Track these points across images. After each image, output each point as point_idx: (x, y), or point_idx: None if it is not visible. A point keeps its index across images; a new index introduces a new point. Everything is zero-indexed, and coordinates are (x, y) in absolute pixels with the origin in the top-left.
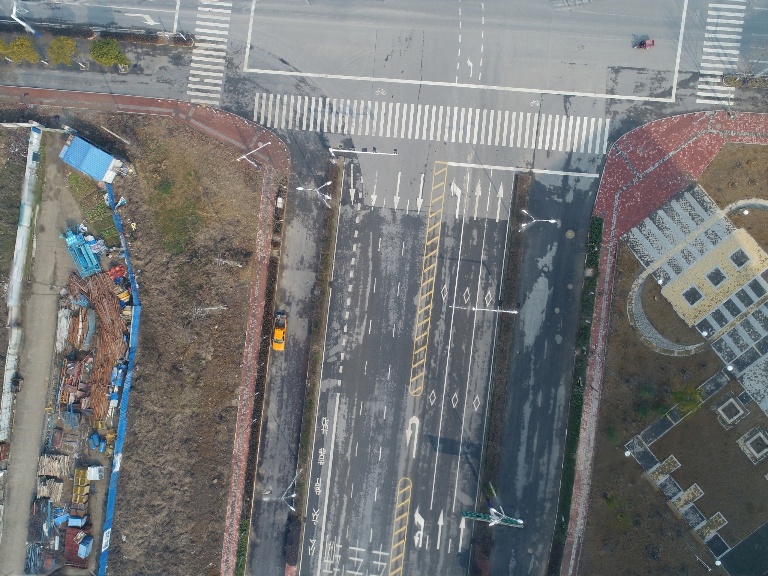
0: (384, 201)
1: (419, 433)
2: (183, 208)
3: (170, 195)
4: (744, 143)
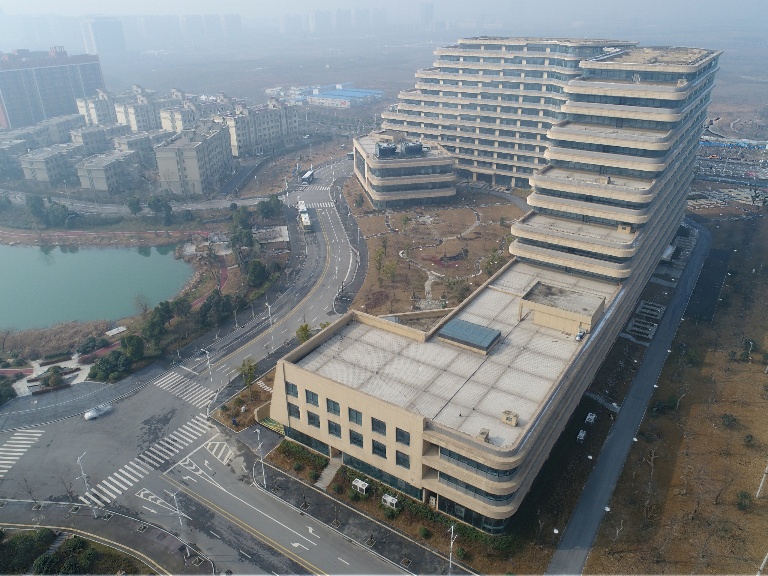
0: (764, 170)
1: None
2: None
3: (762, 153)
4: None
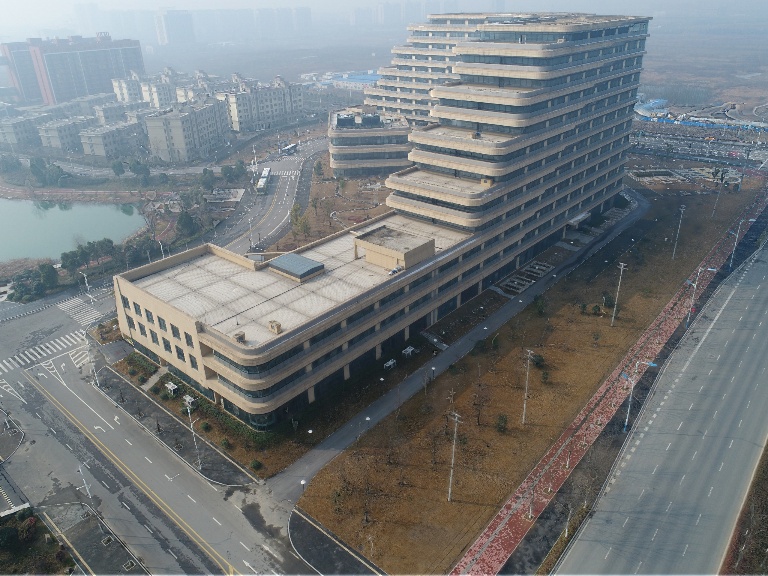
0: None
1: (666, 146)
2: (761, 136)
3: None
4: (767, 182)
